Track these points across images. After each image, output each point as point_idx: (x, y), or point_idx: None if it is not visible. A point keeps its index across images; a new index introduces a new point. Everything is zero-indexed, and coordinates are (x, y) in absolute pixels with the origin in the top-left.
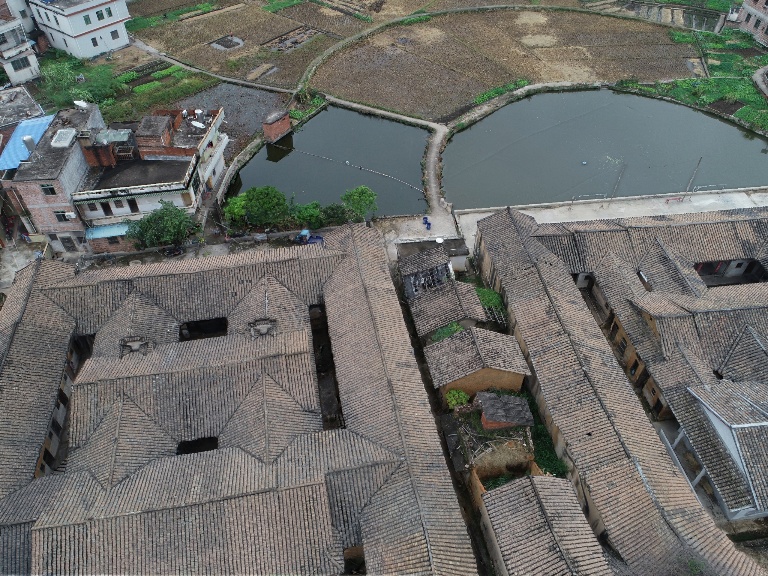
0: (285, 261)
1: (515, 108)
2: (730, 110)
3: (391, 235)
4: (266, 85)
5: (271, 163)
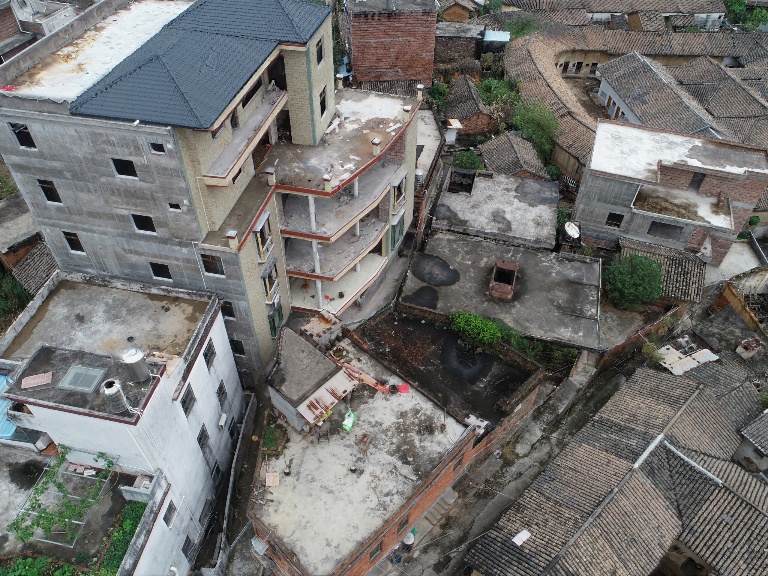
0: None
1: None
2: None
3: None
4: None
5: None
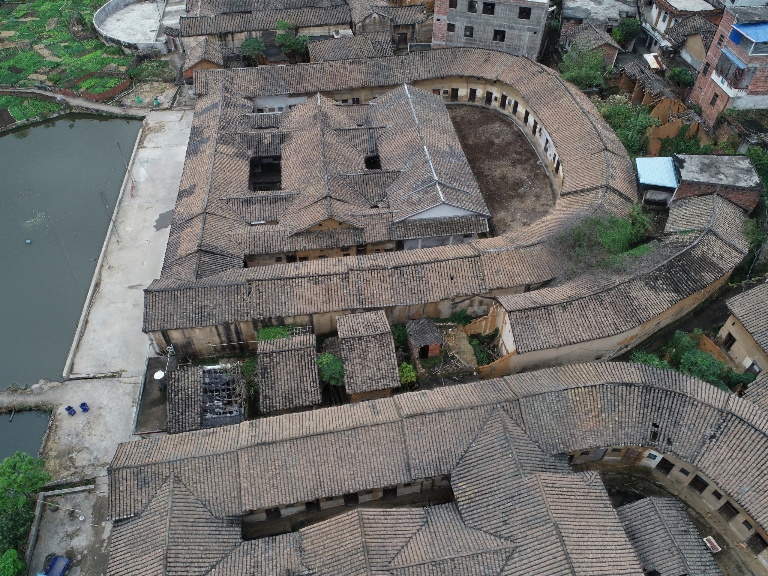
0: (166, 567)
1: None
2: (7, 120)
3: (81, 457)
4: None
5: None
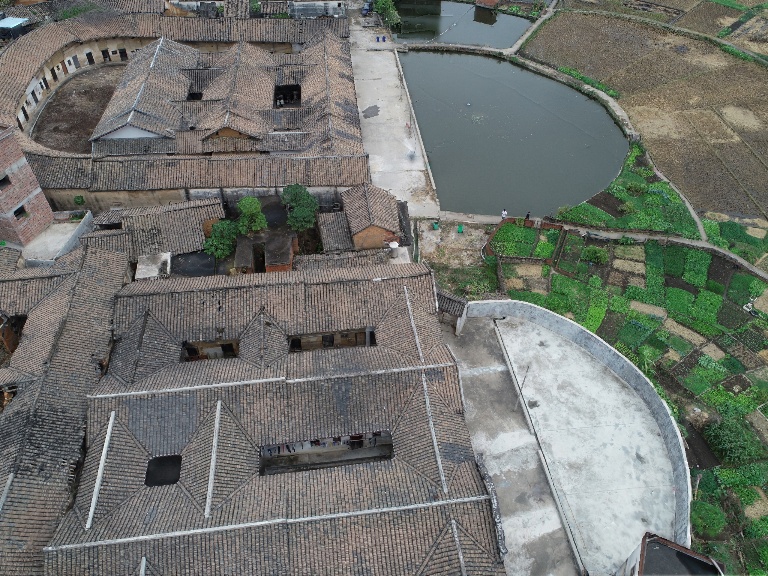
0: None
1: (569, 93)
2: (599, 204)
3: (372, 32)
4: (558, 1)
5: (472, 20)
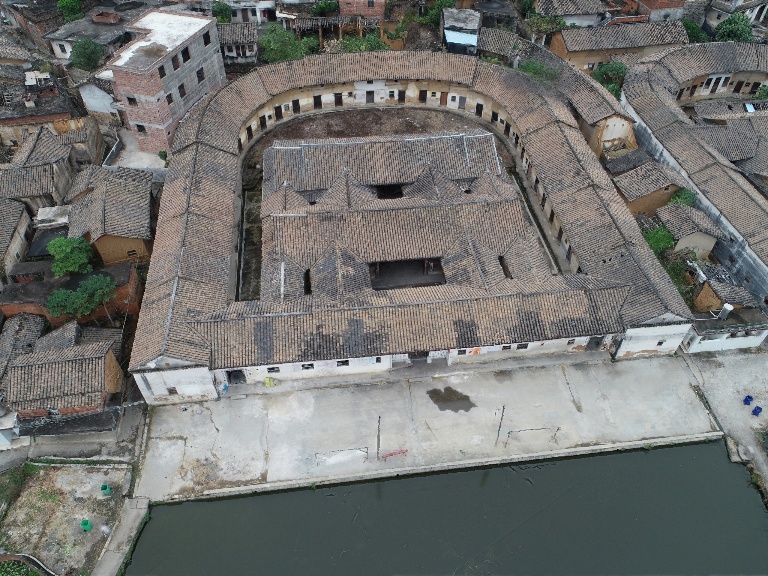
0: None
1: None
2: None
3: None
4: None
5: None
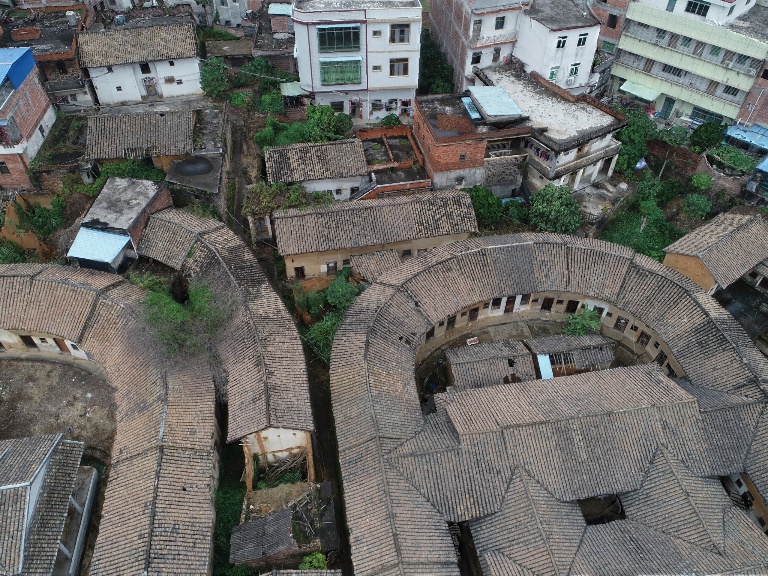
0: None
1: None
2: None
3: None
4: None
5: None
